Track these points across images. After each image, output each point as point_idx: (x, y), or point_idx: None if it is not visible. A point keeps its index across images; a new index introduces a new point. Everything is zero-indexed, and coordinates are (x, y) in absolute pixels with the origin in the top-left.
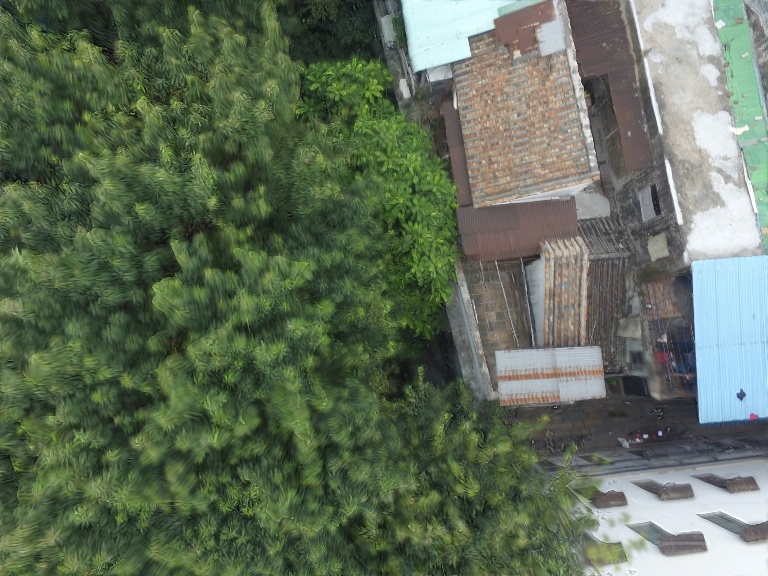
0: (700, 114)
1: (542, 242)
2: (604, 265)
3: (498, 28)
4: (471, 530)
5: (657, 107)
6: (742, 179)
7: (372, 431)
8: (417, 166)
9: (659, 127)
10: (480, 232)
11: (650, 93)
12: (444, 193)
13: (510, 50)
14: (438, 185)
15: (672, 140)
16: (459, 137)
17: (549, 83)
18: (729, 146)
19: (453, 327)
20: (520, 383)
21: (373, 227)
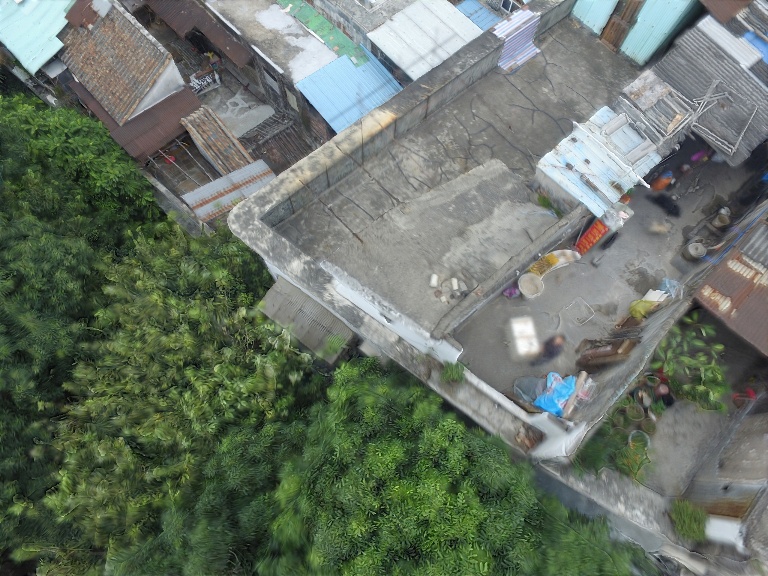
0: (259, 13)
1: (180, 120)
2: (281, 138)
3: (70, 20)
4: (161, 261)
5: (229, 23)
6: (306, 31)
7: (38, 231)
8: (62, 122)
9: (236, 32)
10: (135, 138)
11: (220, 18)
12: (91, 127)
13: (85, 27)
14: (83, 124)
15: (249, 34)
16: (90, 96)
17: (117, 29)
18: (287, 20)
19: (177, 220)
20: (211, 204)
21: (20, 152)
